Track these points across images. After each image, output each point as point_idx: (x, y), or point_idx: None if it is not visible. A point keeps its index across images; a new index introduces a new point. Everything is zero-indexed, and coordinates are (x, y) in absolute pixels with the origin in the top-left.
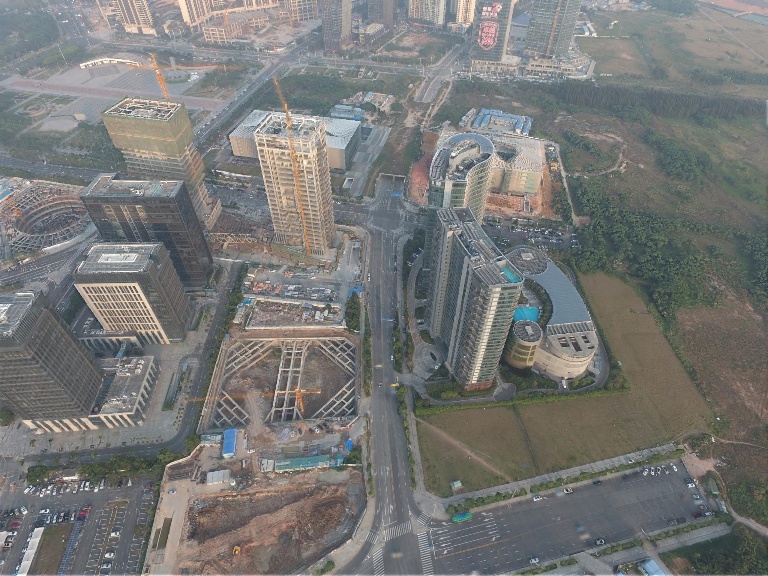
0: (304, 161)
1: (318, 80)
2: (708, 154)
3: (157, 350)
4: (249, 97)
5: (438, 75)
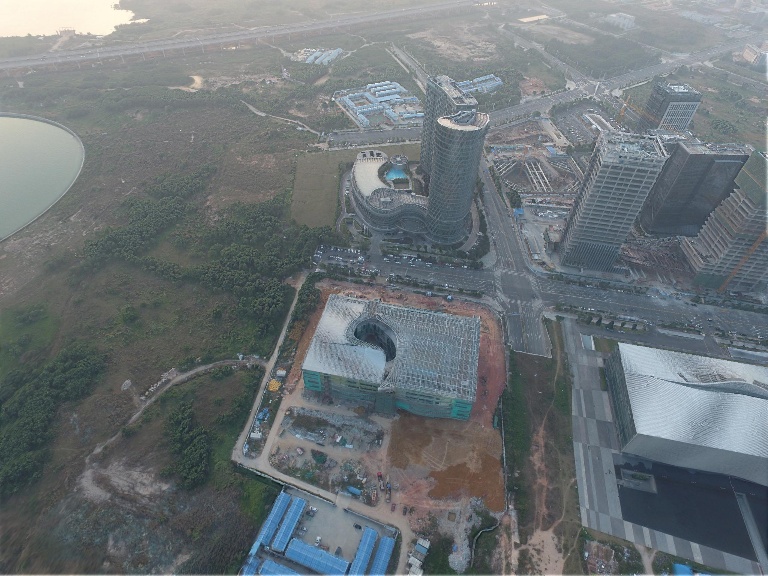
0: None
1: None
2: None
3: None
4: None
5: None
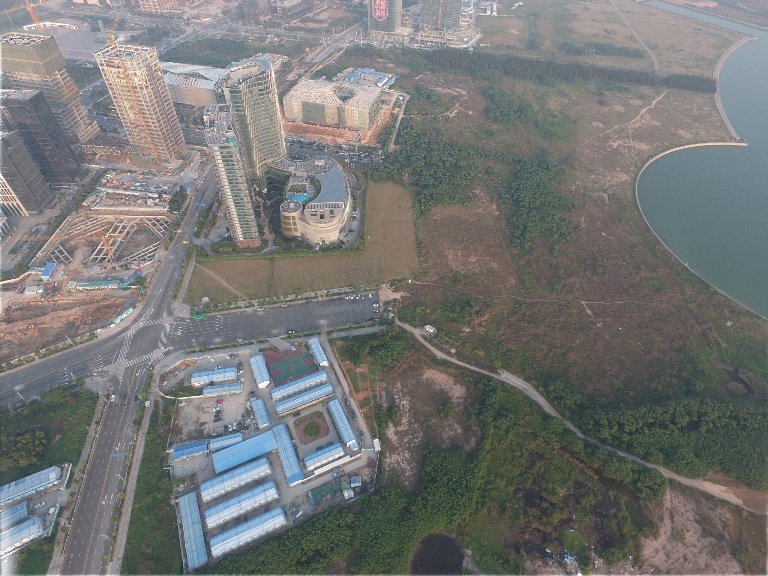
0: (135, 78)
1: (226, 43)
2: (530, 104)
3: (18, 219)
4: (160, 54)
5: (337, 42)
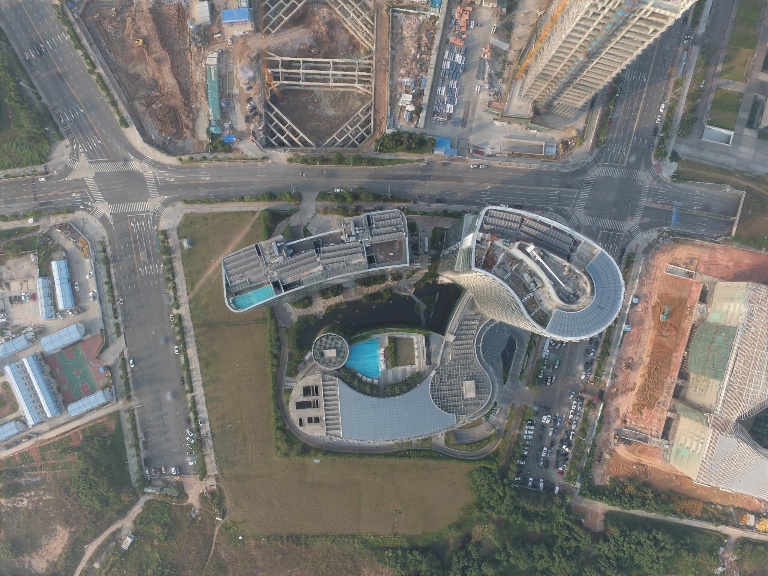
0: None
1: None
2: None
3: None
4: None
5: None
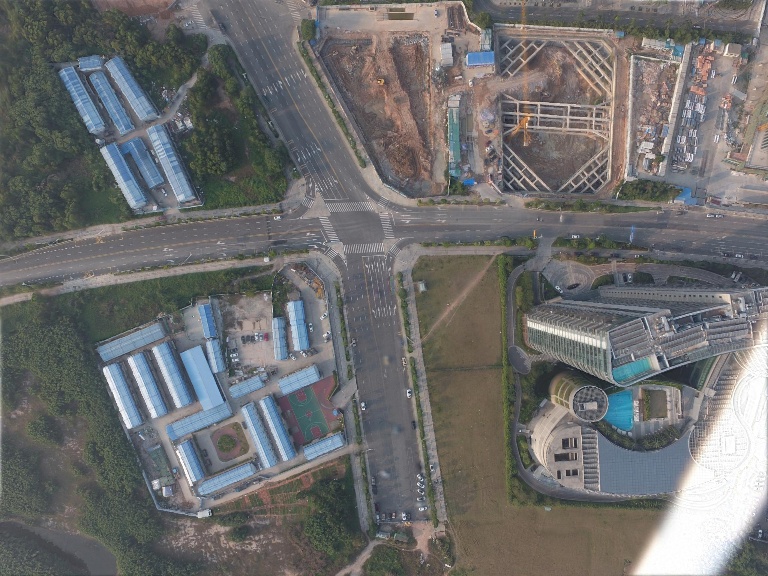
0: None
1: None
2: None
3: None
4: None
5: None
